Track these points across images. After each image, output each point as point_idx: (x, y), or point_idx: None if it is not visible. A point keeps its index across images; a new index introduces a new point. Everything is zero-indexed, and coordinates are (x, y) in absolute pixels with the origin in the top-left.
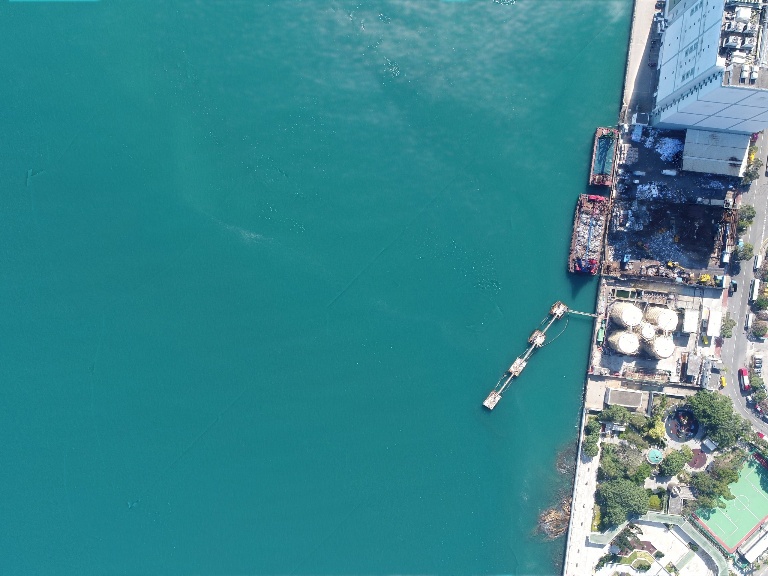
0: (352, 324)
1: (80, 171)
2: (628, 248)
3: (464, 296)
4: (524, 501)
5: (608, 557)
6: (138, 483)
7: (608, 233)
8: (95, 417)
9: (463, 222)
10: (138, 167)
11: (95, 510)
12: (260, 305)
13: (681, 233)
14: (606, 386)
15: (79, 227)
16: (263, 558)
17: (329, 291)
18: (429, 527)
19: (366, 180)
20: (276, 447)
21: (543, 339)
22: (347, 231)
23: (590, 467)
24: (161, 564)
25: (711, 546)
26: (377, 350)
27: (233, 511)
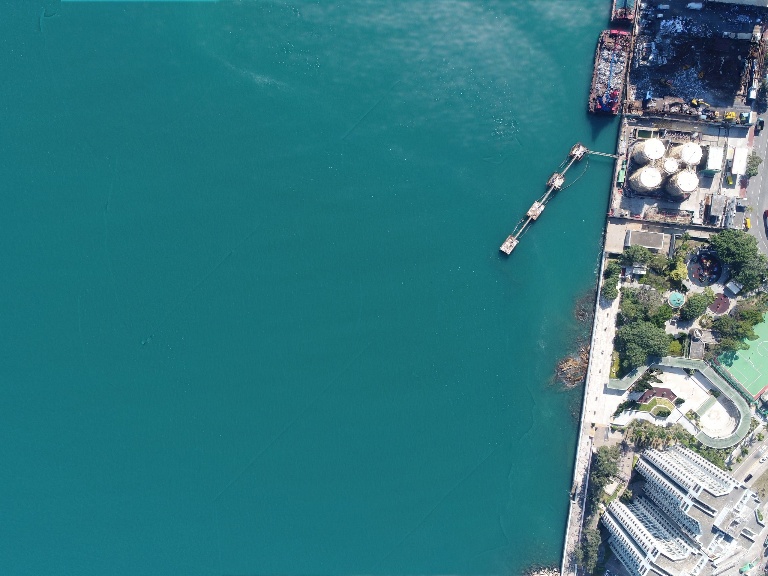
0: (367, 156)
1: (93, 15)
2: (651, 86)
3: (481, 144)
4: (541, 349)
5: (627, 403)
6: (152, 320)
7: (630, 71)
8: (109, 253)
9: (481, 51)
10: (151, 11)
11: (109, 353)
12: (274, 139)
13: (706, 69)
14: (626, 229)
15: (92, 63)
16: (277, 395)
17: (344, 123)
18: (444, 364)
19: (382, 8)
20: (290, 281)
21: (562, 181)
22: (362, 61)
23: (609, 313)
24: (175, 403)
25: (733, 391)
26: (392, 183)
27: (247, 348)
